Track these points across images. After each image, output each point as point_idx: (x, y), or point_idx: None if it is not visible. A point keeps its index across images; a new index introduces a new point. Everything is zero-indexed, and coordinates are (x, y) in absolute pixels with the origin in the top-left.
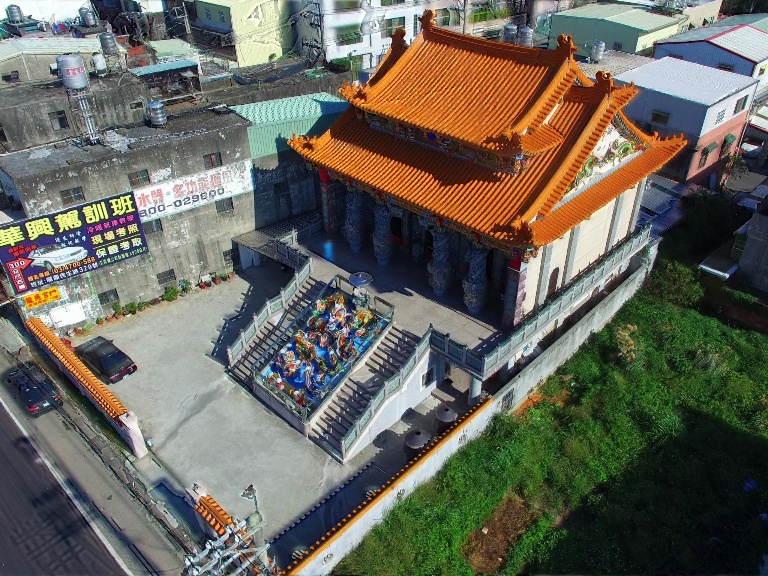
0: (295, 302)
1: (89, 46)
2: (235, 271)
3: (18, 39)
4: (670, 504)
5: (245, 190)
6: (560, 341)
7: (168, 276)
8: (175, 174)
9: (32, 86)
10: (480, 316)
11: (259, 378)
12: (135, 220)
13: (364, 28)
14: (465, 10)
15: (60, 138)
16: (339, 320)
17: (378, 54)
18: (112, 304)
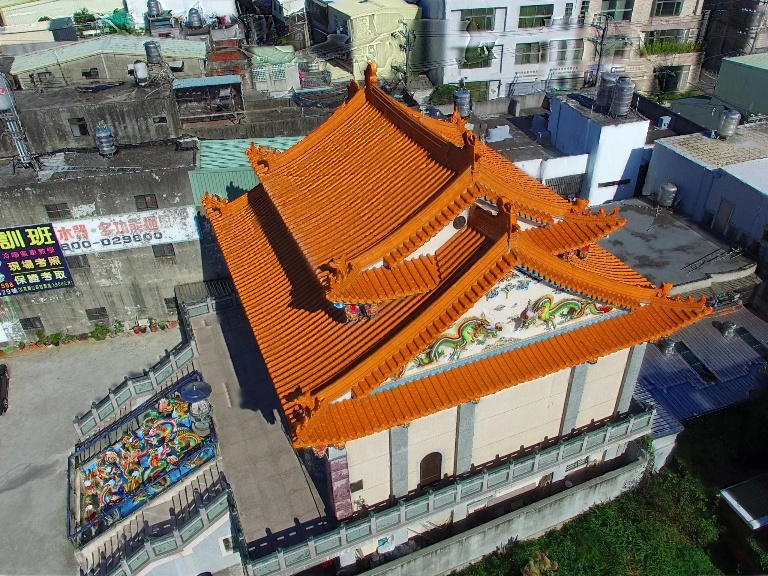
0: (167, 387)
1: (173, 49)
2: (179, 320)
3: (115, 36)
4: None
5: (189, 238)
6: (429, 550)
7: (100, 313)
8: (101, 211)
9: (75, 88)
10: (322, 484)
11: (82, 470)
12: (56, 252)
13: (471, 54)
14: (602, 43)
15: (10, 154)
16: (163, 434)
17: (509, 82)
18: (36, 331)
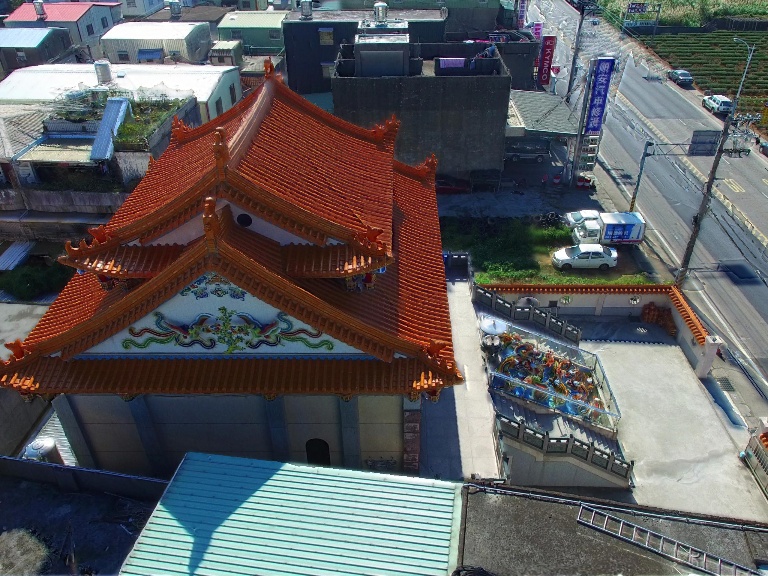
0: None
1: None
2: None
3: None
4: None
5: None
6: None
7: None
8: None
9: None
10: None
11: None
12: None
13: None
14: None
15: None
16: None
17: None
18: None
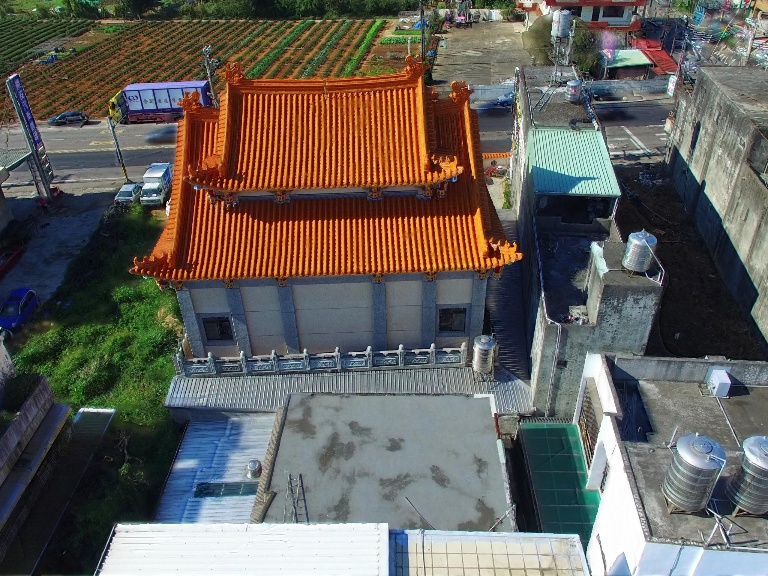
0: None
1: None
2: None
3: None
4: (115, 275)
5: None
6: None
7: None
8: None
9: None
10: None
11: None
12: None
13: None
14: None
15: None
16: None
17: None
18: None
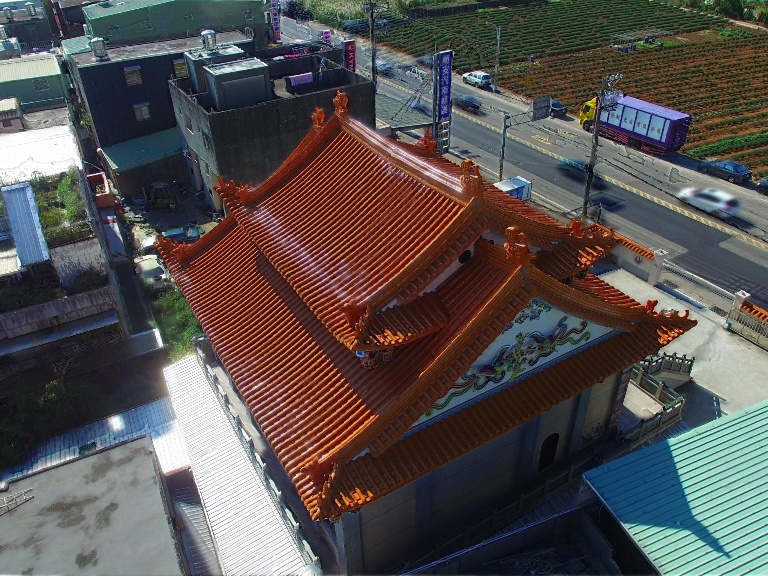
0: None
1: None
2: None
3: None
4: None
5: None
6: None
7: None
8: None
9: None
10: None
11: None
12: None
13: None
14: None
15: None
16: None
17: None
18: None
